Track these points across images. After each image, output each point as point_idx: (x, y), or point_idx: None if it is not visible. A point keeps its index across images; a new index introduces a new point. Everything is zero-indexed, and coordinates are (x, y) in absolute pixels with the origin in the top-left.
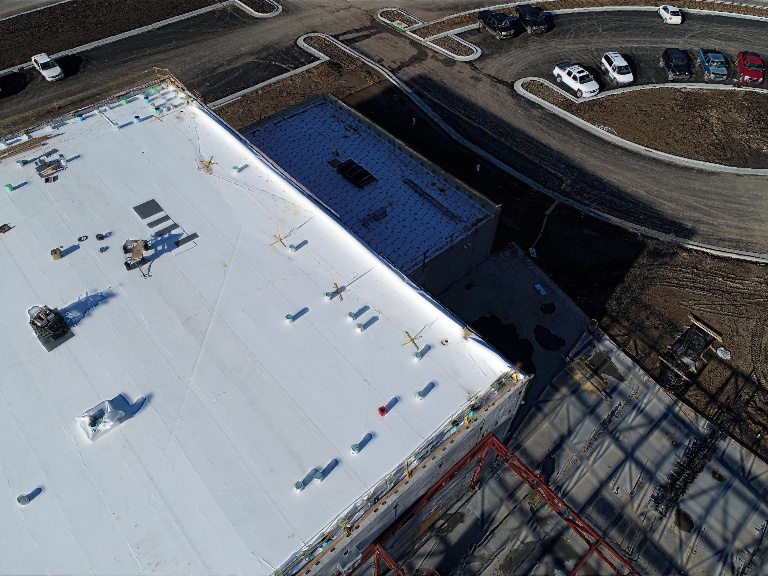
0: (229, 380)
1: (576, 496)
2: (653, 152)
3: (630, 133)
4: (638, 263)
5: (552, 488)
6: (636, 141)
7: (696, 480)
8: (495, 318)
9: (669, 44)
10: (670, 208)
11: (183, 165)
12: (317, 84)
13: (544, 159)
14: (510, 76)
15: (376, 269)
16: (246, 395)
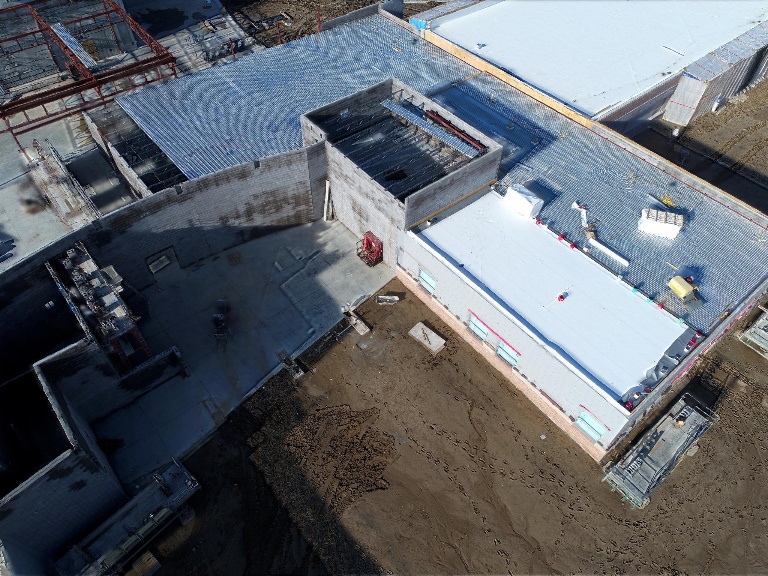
0: None
1: None
2: None
3: None
4: None
5: None
6: None
7: None
8: (176, 9)
9: None
10: None
11: None
12: None
13: None
14: None
15: None
16: None
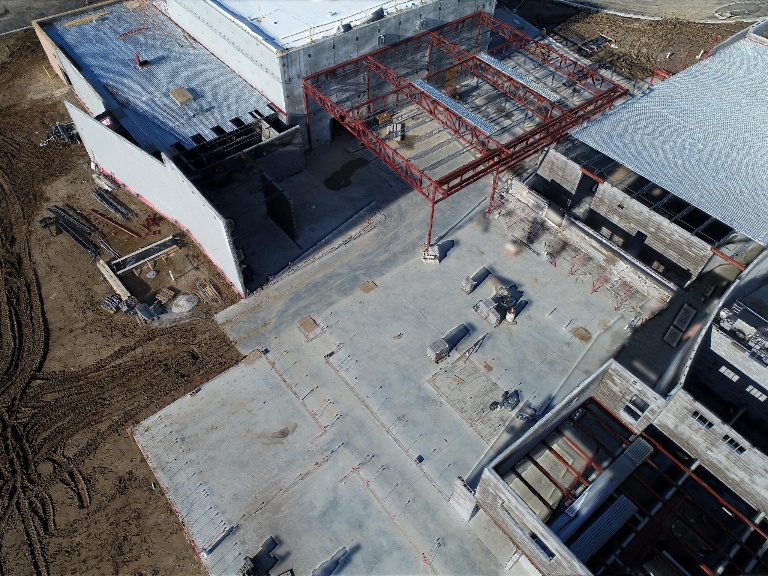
0: None
1: None
2: None
3: None
4: (576, 16)
5: None
6: None
7: None
8: None
9: None
10: None
11: None
12: None
13: None
14: None
15: None
16: None
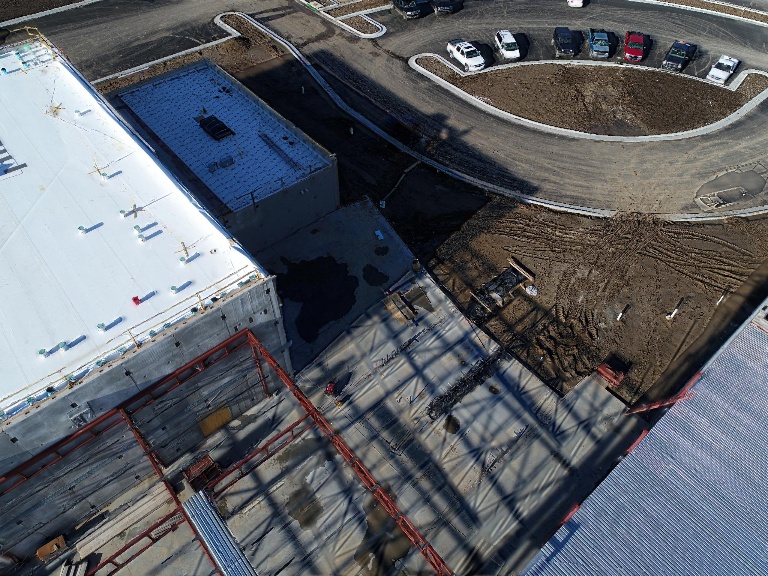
0: (14, 276)
1: (362, 403)
2: (522, 120)
3: (505, 103)
4: (477, 215)
5: (342, 396)
6: (509, 110)
7: (473, 393)
8: (331, 258)
9: (566, 25)
10: (523, 169)
11: (33, 109)
12: (223, 57)
13: (418, 125)
14: (407, 52)
15: (174, 194)
16: (25, 287)
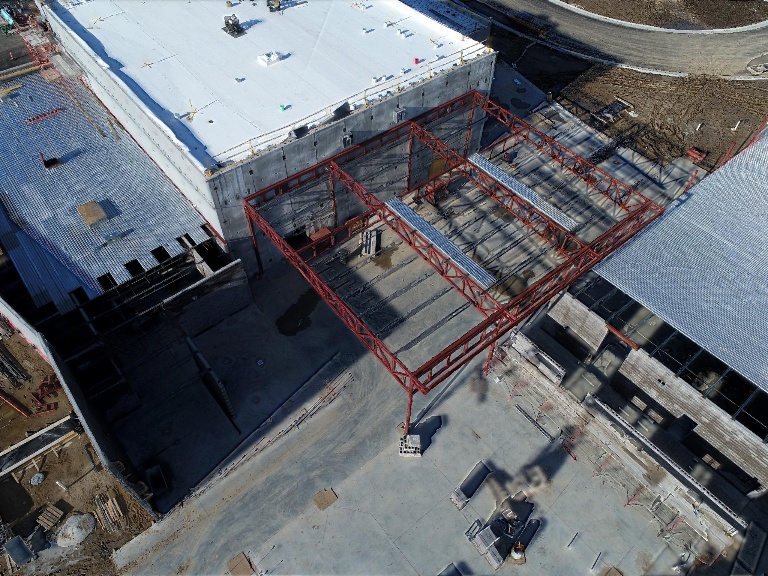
0: (334, 50)
1: (528, 167)
2: (608, 19)
3: (593, 8)
4: (586, 73)
5: (514, 163)
6: (597, 13)
7: (602, 163)
8: None
9: None
10: (614, 48)
11: None
12: None
13: (529, 21)
14: None
15: (413, 17)
16: (344, 55)
